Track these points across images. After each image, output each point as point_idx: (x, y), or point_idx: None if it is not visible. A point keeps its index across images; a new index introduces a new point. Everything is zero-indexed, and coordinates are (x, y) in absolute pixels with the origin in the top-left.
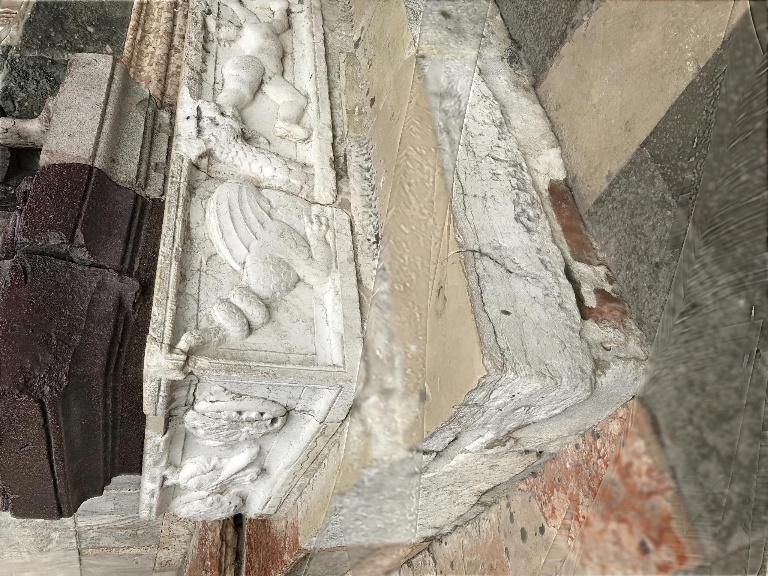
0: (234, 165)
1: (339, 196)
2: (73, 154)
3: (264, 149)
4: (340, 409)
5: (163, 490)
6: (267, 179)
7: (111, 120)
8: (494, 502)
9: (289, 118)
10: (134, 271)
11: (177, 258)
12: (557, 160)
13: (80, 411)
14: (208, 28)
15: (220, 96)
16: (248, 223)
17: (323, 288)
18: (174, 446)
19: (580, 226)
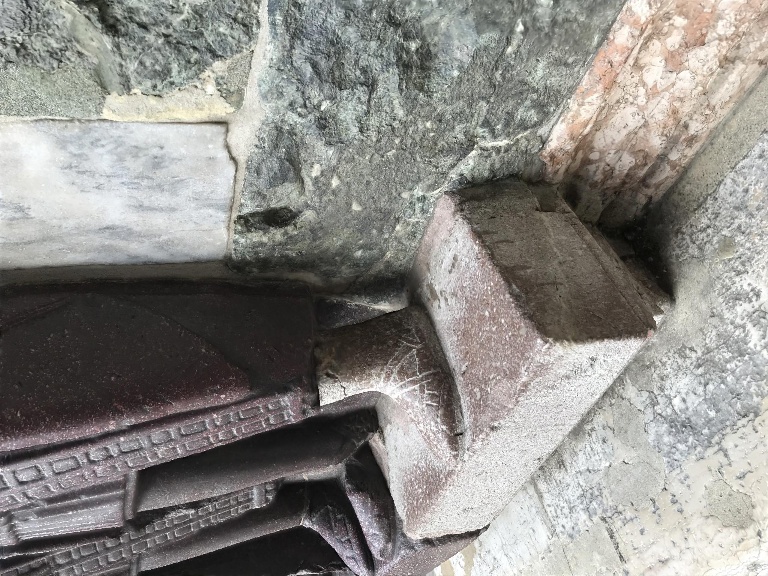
0: None
1: None
2: (460, 530)
3: None
4: None
5: None
6: None
7: None
8: None
9: None
10: None
11: None
12: None
13: None
14: None
15: None
16: None
17: None
18: None
19: None
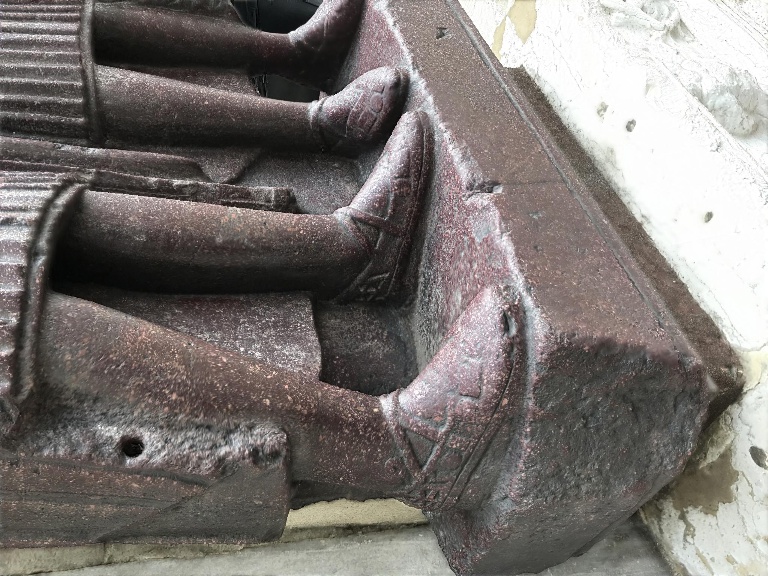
0: None
1: None
2: None
3: None
4: None
5: None
6: None
7: None
8: None
9: None
10: None
11: None
12: None
13: None
14: None
15: None
16: None
17: None
18: None
19: None
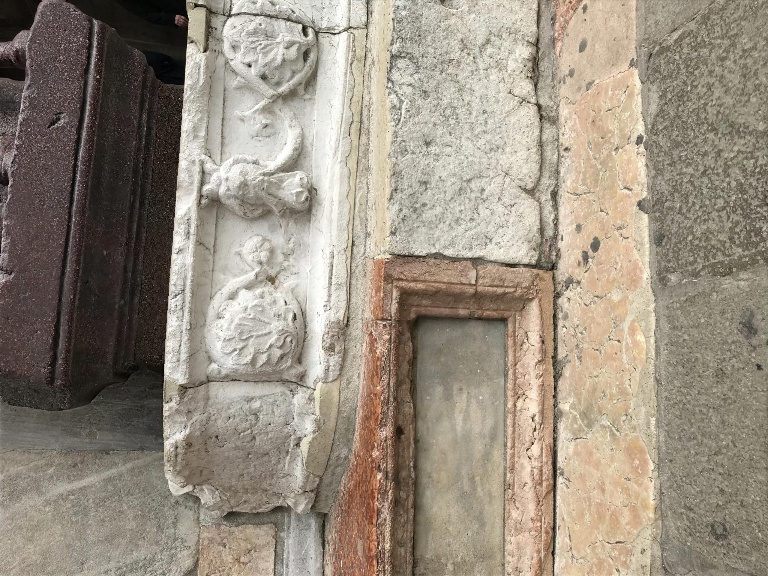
0: None
1: None
2: None
3: None
4: (358, 2)
5: (200, 244)
6: None
7: None
8: (557, 107)
9: None
10: None
11: None
12: None
13: (117, 105)
14: None
15: None
16: None
17: None
18: (213, 110)
19: None
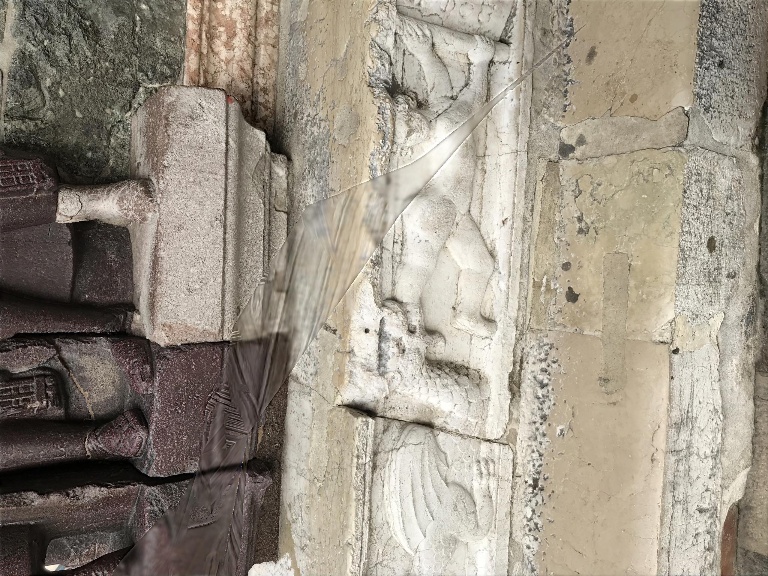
0: (410, 395)
1: (508, 426)
2: (198, 328)
3: (447, 375)
4: None
5: None
6: (442, 411)
7: (234, 241)
8: None
9: (475, 309)
10: (258, 444)
11: (364, 573)
12: (742, 479)
13: None
14: (395, 138)
15: (403, 281)
16: (428, 502)
17: (477, 545)
18: None
19: (733, 561)
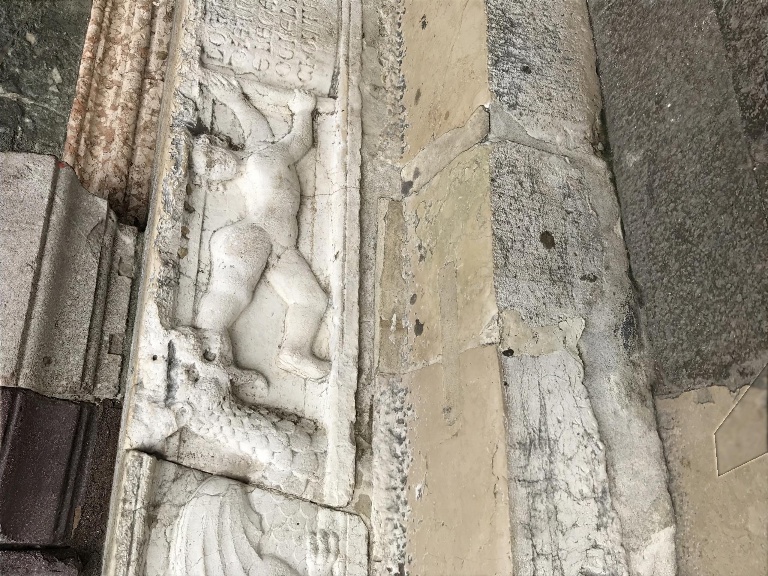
0: (216, 440)
1: (357, 491)
2: None
3: (260, 416)
4: None
5: None
6: (261, 464)
7: (47, 289)
8: None
9: (300, 345)
10: (73, 529)
11: None
12: (668, 545)
13: None
14: (194, 168)
15: (204, 308)
16: (228, 575)
17: None
18: None
19: None
